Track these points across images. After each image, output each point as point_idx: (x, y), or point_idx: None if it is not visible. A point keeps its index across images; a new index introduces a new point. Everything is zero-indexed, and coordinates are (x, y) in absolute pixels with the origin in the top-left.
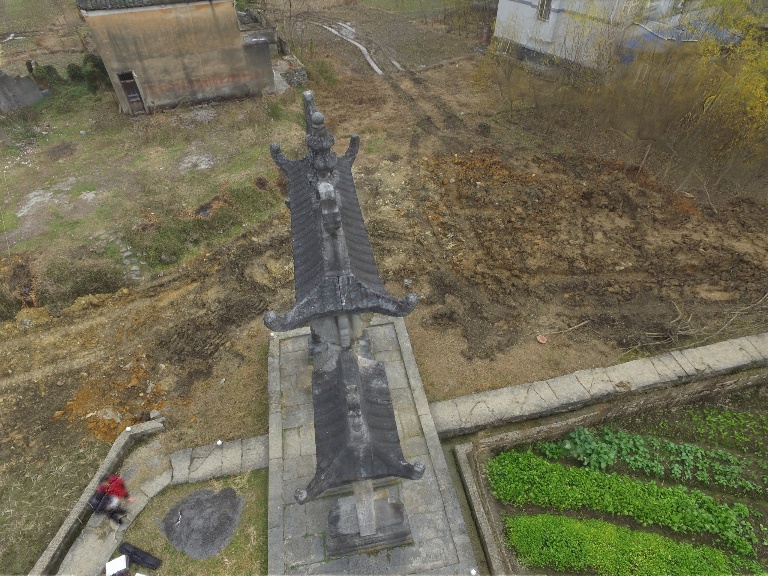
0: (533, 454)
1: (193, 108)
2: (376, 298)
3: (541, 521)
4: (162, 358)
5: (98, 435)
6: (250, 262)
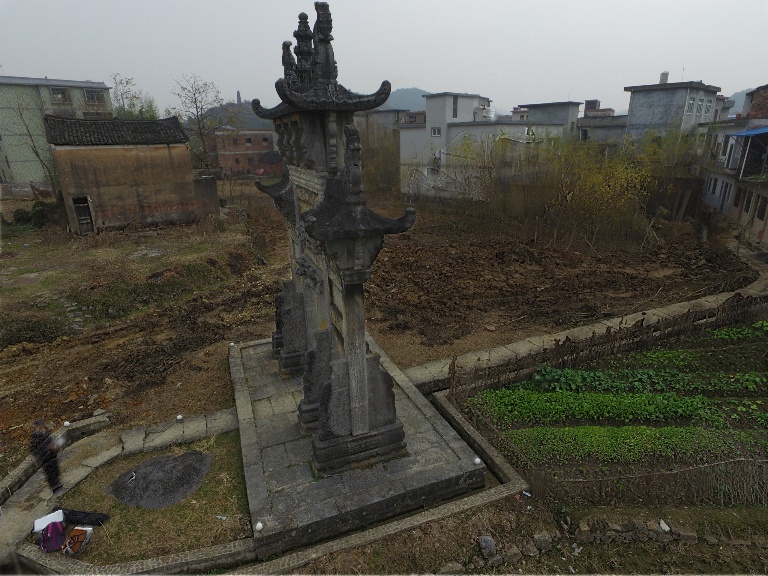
0: None
1: (141, 230)
2: (358, 98)
3: (532, 430)
4: (108, 376)
5: (24, 440)
6: (202, 315)
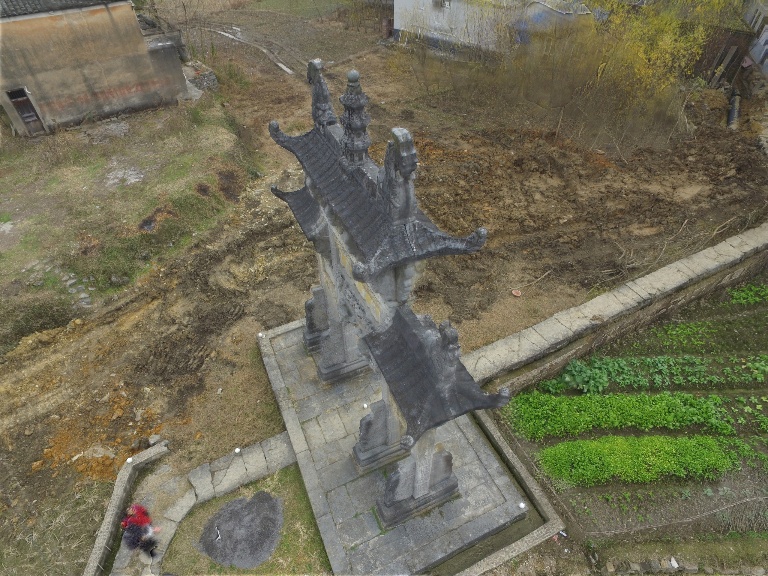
0: (539, 393)
1: (101, 123)
2: (442, 240)
3: (563, 448)
4: (144, 382)
5: (93, 476)
6: (211, 270)
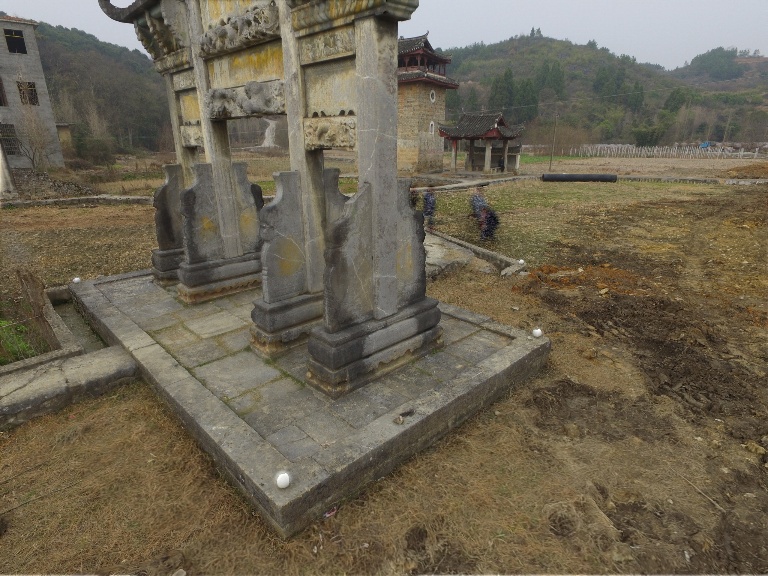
0: None
1: None
2: None
3: None
4: None
5: None
6: None
